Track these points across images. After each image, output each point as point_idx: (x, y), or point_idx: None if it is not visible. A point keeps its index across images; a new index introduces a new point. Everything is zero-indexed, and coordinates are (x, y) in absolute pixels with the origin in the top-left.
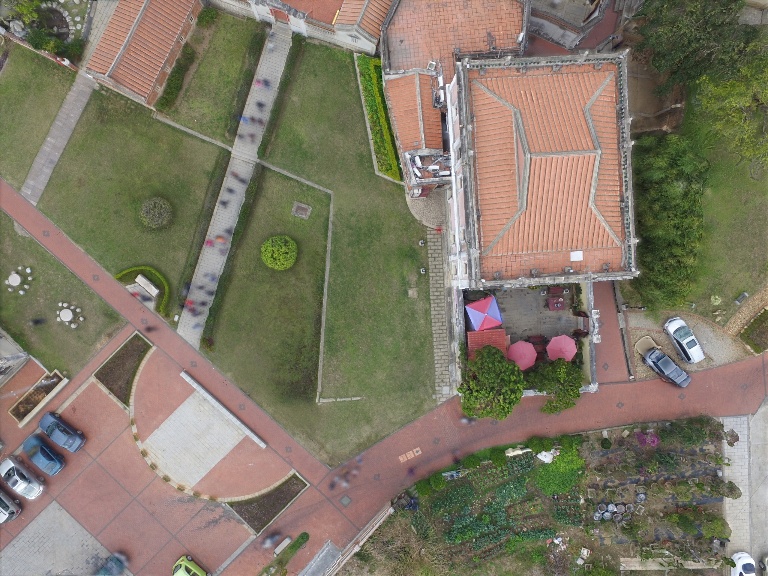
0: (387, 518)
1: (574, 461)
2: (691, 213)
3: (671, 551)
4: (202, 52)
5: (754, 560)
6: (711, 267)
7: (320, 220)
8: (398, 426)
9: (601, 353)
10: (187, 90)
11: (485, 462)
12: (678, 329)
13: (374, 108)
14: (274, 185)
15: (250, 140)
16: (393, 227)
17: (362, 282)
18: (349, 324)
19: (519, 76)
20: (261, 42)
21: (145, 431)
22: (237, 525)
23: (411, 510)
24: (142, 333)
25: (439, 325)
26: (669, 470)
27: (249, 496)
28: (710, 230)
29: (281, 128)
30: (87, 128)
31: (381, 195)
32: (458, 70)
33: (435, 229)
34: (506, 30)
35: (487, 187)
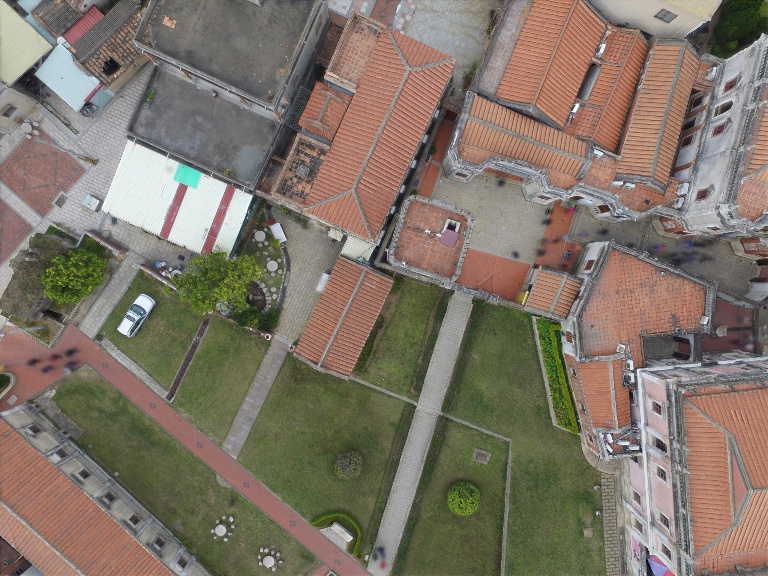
0: None
1: None
2: None
3: None
4: (389, 316)
5: None
6: None
7: (498, 465)
8: None
9: None
10: (375, 352)
11: None
12: None
13: (554, 368)
14: (455, 434)
15: (434, 395)
16: (569, 473)
17: (540, 523)
18: (528, 561)
19: (726, 393)
20: (446, 309)
21: None
22: None
23: None
24: (336, 573)
25: (612, 560)
26: None
27: None
28: None
29: (463, 383)
30: (282, 387)
31: (558, 444)
32: (668, 386)
33: (609, 474)
34: (689, 311)
35: (698, 497)
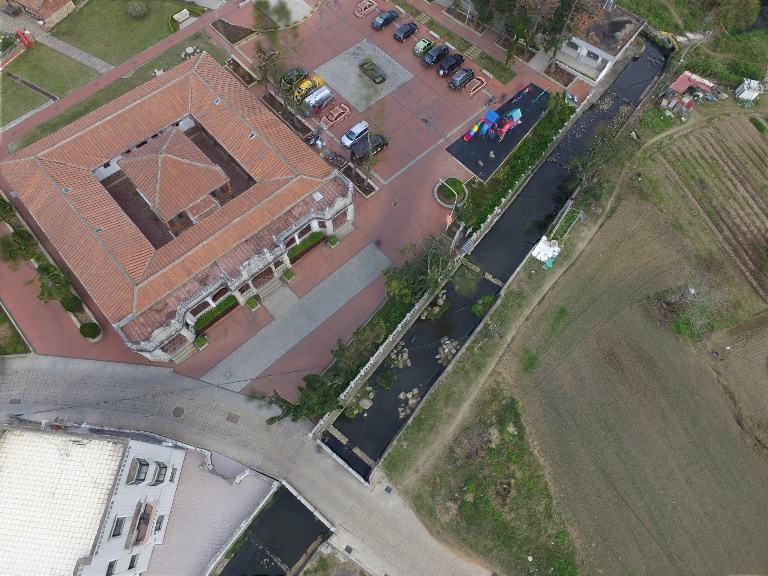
0: None
1: None
2: None
3: None
4: None
5: None
6: None
7: None
8: None
9: None
10: None
11: None
12: None
13: None
14: None
15: None
16: None
17: None
18: None
19: None
20: None
21: (274, 25)
22: None
23: None
24: None
25: None
26: None
27: None
28: None
29: None
30: (74, 40)
31: None
32: None
33: None
34: None
35: None
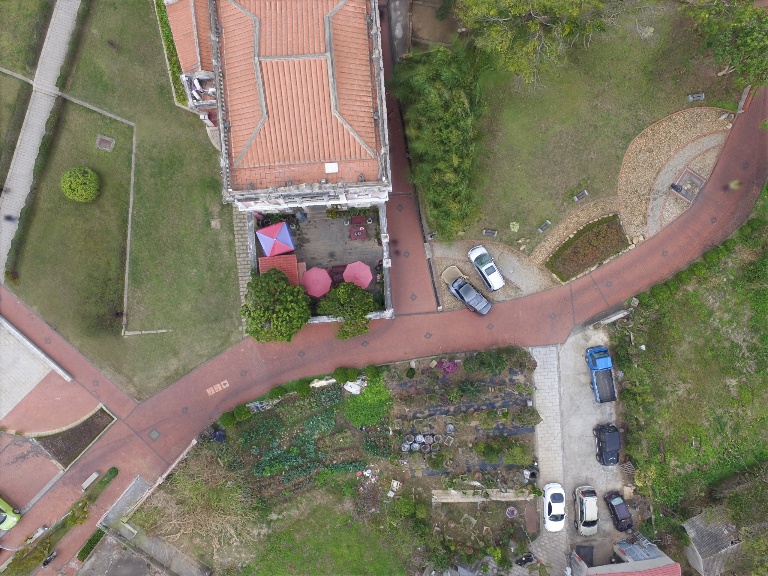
0: (193, 451)
1: (382, 392)
2: (456, 128)
3: (483, 483)
4: None
5: (568, 491)
6: (513, 195)
7: (124, 153)
8: (205, 359)
9: (408, 283)
10: None
11: (291, 393)
12: (479, 256)
13: (170, 38)
14: (77, 118)
15: (51, 73)
16: (195, 158)
17: (165, 214)
18: (153, 256)
19: None
20: None
21: None
22: (45, 460)
23: (217, 442)
24: None
25: (244, 256)
26: (469, 397)
27: (56, 431)
28: (511, 158)
29: (82, 61)
30: None
31: (182, 126)
32: None
33: None
34: None
35: (235, 98)
